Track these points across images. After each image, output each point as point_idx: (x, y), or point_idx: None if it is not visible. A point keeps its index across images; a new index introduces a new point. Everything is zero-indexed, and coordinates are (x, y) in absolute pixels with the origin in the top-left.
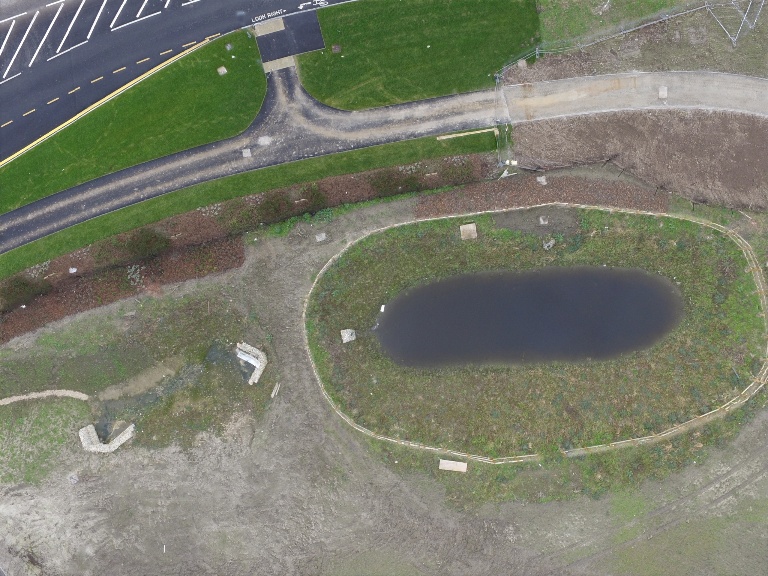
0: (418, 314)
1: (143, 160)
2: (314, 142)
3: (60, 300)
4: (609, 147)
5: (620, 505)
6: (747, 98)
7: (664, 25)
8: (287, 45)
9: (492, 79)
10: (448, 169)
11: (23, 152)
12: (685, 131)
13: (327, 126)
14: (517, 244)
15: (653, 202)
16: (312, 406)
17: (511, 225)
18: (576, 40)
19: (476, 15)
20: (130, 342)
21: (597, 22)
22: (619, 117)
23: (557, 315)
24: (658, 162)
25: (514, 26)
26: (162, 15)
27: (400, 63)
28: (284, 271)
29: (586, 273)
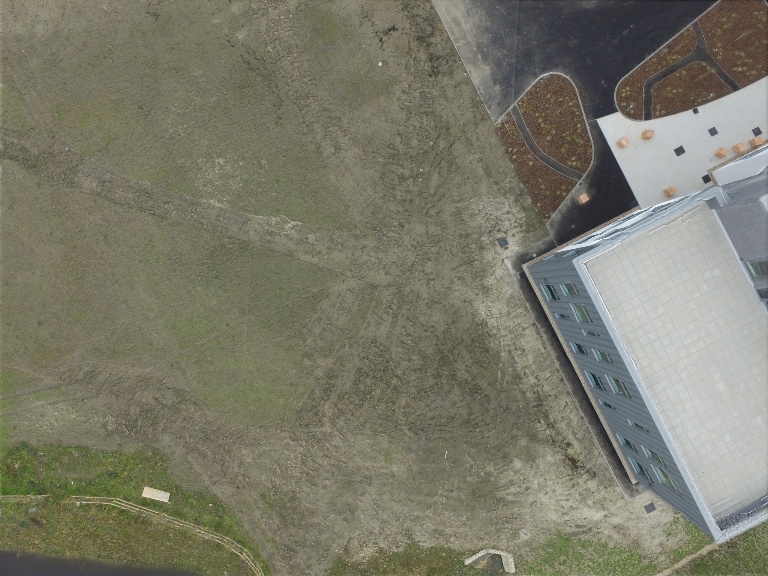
0: None
1: None
2: None
3: None
4: None
5: (2, 434)
6: None
7: None
8: None
9: None
10: None
11: None
12: None
13: None
14: None
15: None
16: (285, 568)
17: None
18: None
19: None
20: None
21: None
22: None
23: None
24: None
25: None
26: None
27: None
28: None
29: None
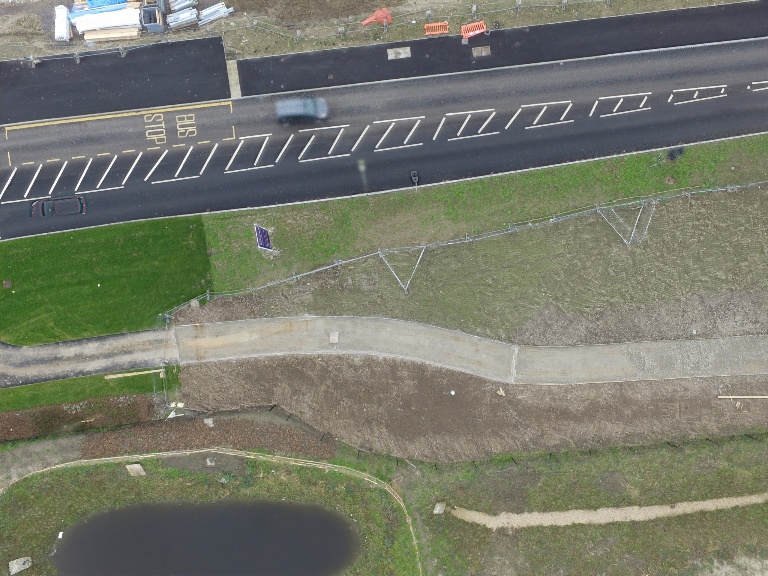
0: (100, 539)
1: None
2: None
3: None
4: (277, 391)
5: None
6: (419, 345)
7: (336, 271)
8: None
9: (163, 319)
10: (114, 409)
11: None
12: (354, 377)
13: None
14: (189, 480)
15: (320, 447)
16: None
17: (178, 465)
18: (248, 283)
19: (147, 256)
20: None
21: (269, 266)
22: (288, 361)
23: (238, 545)
24: (325, 408)
25: (185, 268)
26: None
27: (70, 301)
28: None
29: (267, 505)
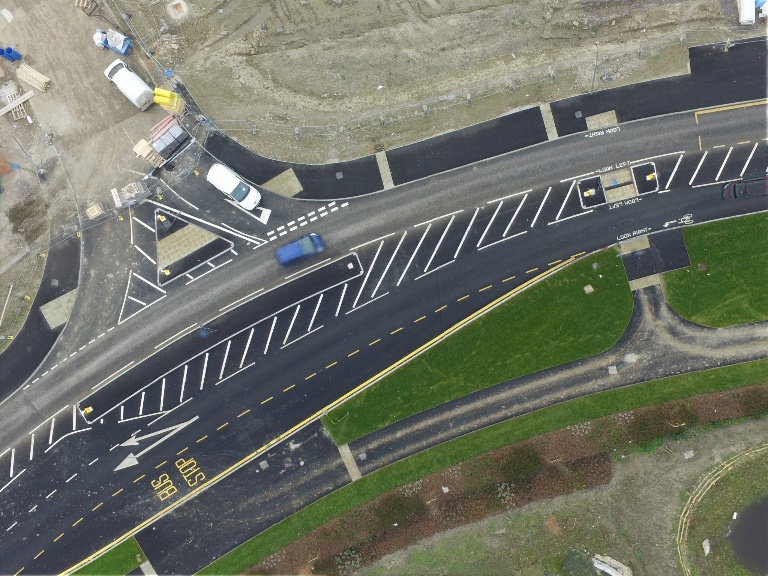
0: (766, 519)
1: (510, 378)
2: (681, 359)
3: (430, 517)
4: None
5: None
6: None
7: None
8: (653, 263)
9: None
10: None
11: (391, 370)
12: None
13: (693, 343)
14: None
15: None
16: None
17: None
18: None
19: None
20: (497, 557)
21: None
22: None
23: None
24: None
25: None
26: (528, 234)
27: (767, 281)
28: (652, 488)
29: None
